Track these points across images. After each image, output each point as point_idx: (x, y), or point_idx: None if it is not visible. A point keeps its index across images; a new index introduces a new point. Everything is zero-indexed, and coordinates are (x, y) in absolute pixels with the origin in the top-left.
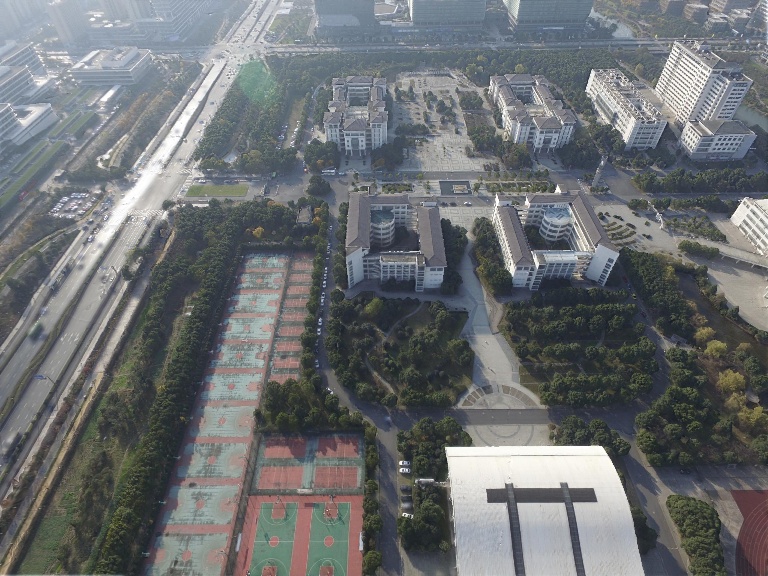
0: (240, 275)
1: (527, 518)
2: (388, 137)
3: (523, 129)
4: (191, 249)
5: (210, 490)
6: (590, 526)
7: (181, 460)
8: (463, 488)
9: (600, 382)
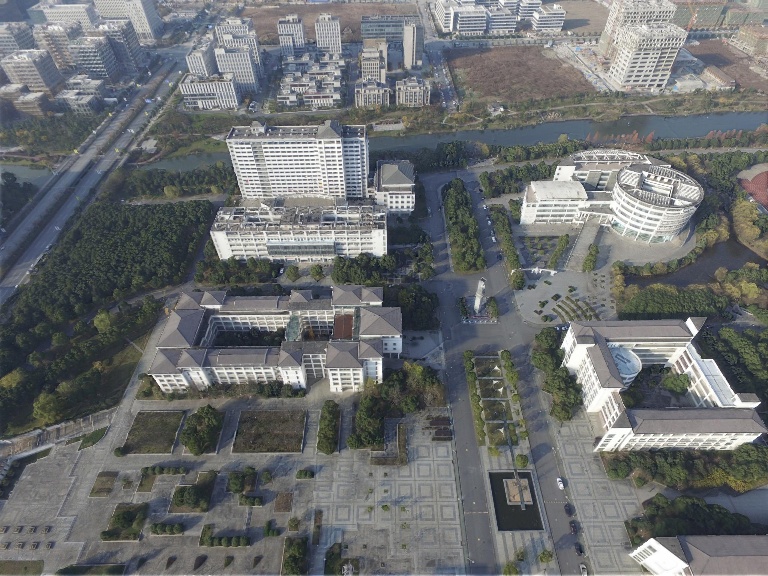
0: None
1: None
2: None
3: None
4: None
5: None
6: None
7: None
8: None
9: None
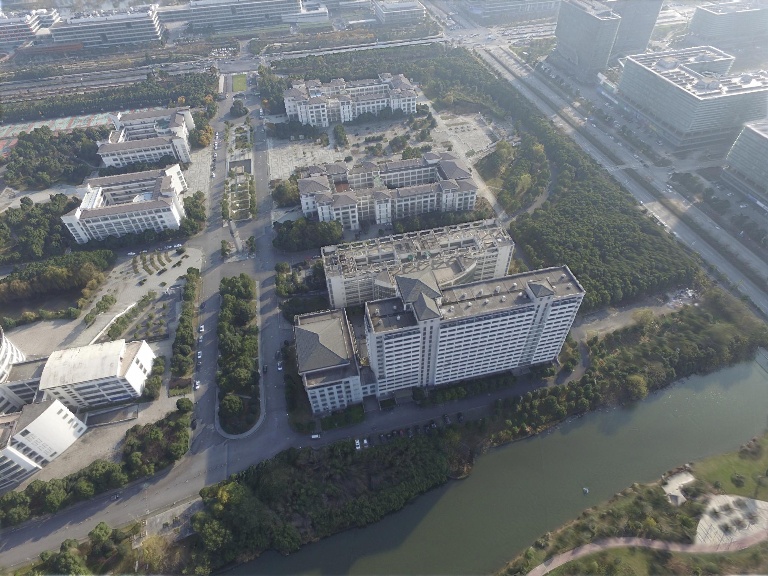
0: (147, 107)
1: None
2: (328, 127)
3: None
4: (168, 86)
5: (5, 131)
6: None
7: (25, 122)
8: None
9: None
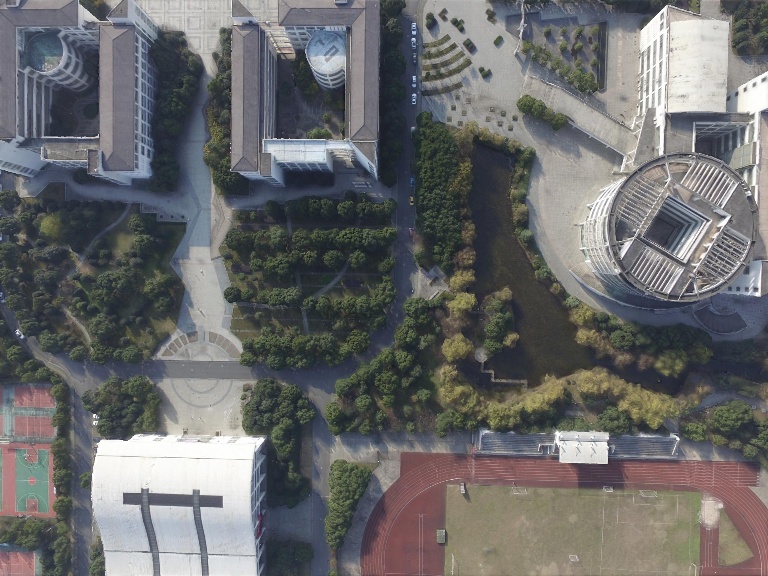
0: None
1: (158, 516)
2: None
3: None
4: None
5: None
6: (213, 524)
7: None
8: (102, 491)
9: (302, 349)
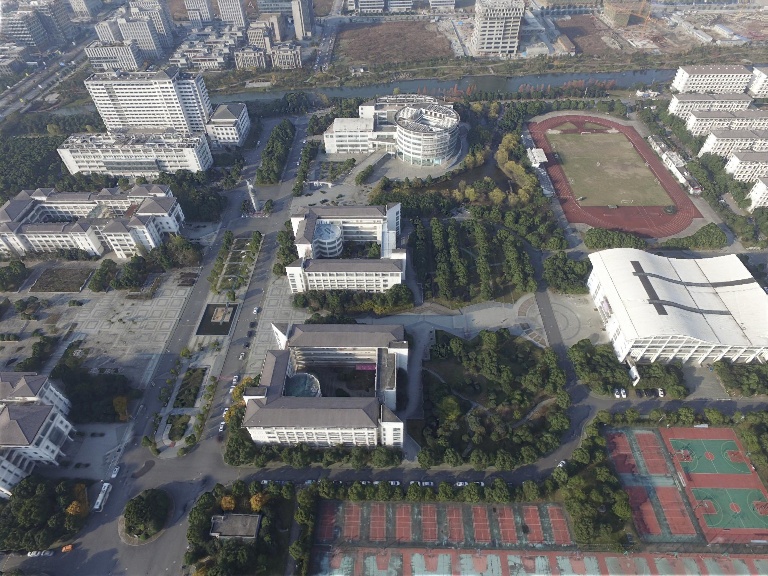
0: None
1: (666, 297)
2: None
3: (150, 229)
4: None
5: None
6: (654, 269)
7: None
8: (665, 328)
9: None
